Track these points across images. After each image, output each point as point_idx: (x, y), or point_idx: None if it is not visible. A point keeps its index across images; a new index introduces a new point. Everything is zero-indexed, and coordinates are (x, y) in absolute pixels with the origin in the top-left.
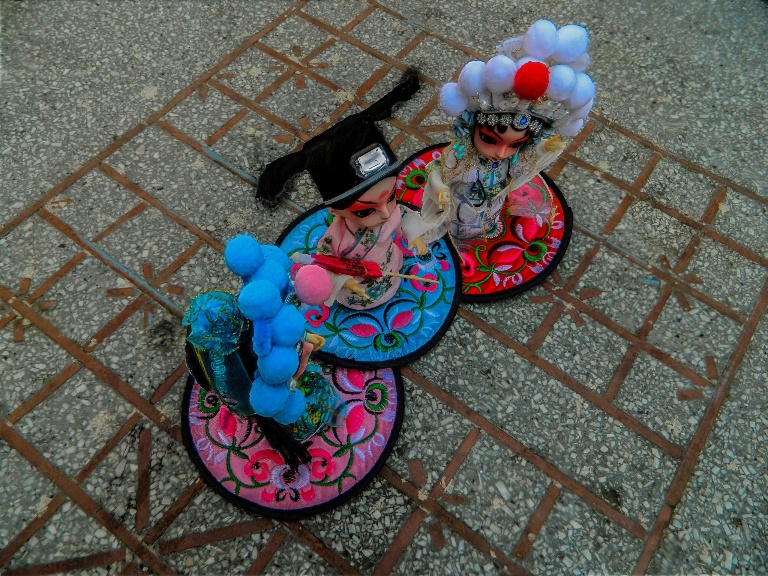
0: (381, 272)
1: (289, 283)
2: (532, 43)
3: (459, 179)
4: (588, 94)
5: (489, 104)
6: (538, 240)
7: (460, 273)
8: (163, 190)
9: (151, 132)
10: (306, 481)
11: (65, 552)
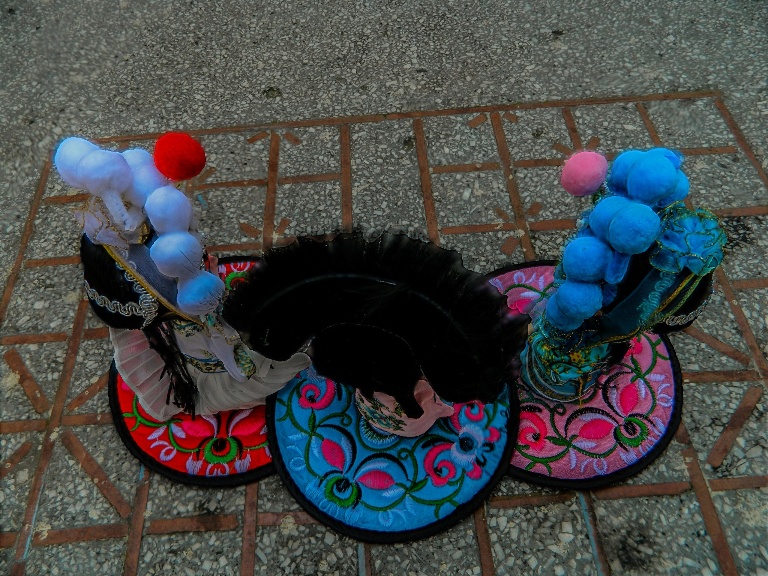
0: None
1: (587, 226)
2: (123, 171)
3: None
4: None
5: None
6: None
7: None
8: None
9: None
10: None
11: None
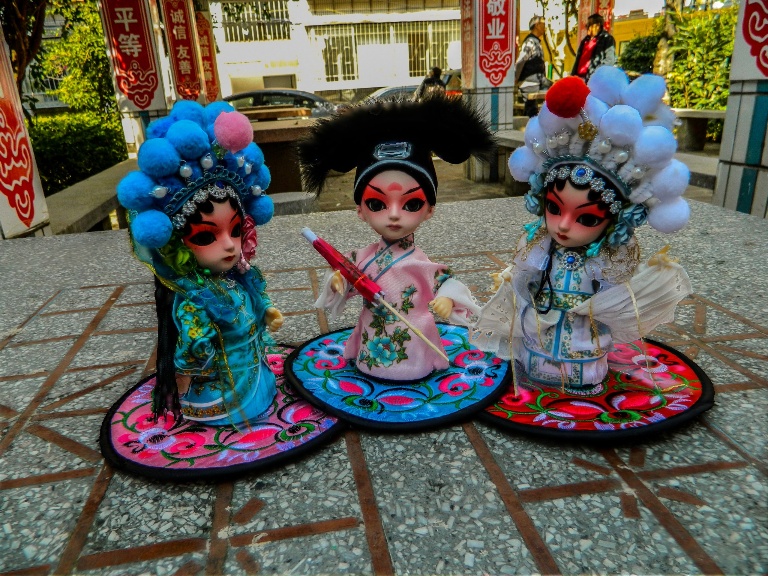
0: (377, 292)
1: None
2: (590, 81)
3: (525, 266)
4: (657, 139)
5: (546, 151)
6: (634, 410)
7: (498, 392)
8: None
9: None
10: (160, 447)
11: (0, 396)
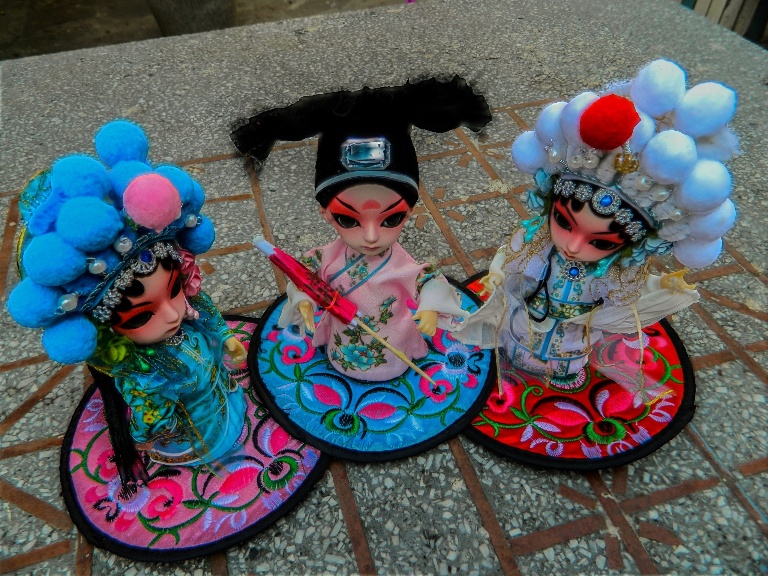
0: None
1: None
2: (637, 83)
3: None
4: (712, 189)
5: (564, 161)
6: (619, 420)
7: (483, 399)
8: (274, 192)
9: (306, 150)
10: (136, 508)
11: None
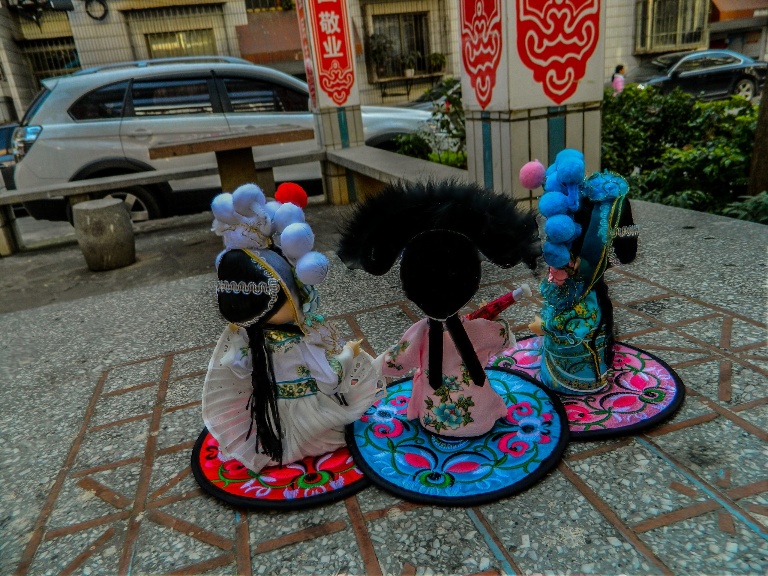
0: None
1: None
2: None
3: None
4: None
5: None
6: None
7: None
8: None
9: None
10: None
11: None
